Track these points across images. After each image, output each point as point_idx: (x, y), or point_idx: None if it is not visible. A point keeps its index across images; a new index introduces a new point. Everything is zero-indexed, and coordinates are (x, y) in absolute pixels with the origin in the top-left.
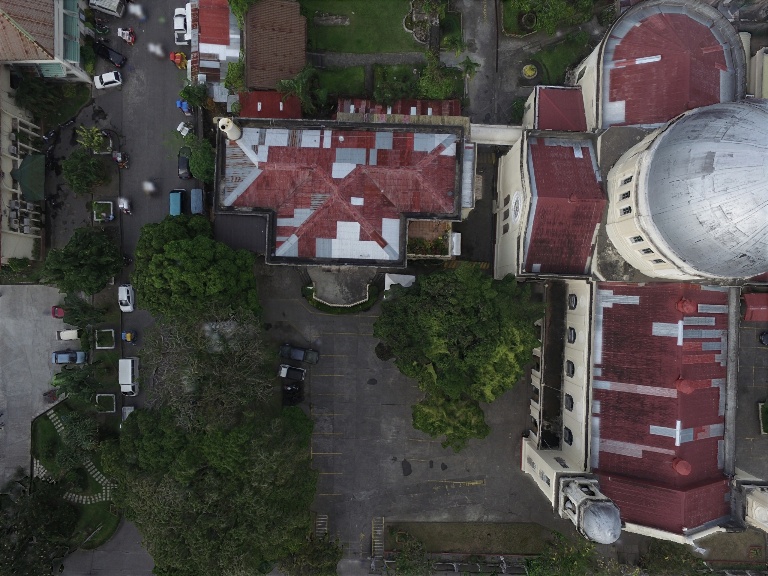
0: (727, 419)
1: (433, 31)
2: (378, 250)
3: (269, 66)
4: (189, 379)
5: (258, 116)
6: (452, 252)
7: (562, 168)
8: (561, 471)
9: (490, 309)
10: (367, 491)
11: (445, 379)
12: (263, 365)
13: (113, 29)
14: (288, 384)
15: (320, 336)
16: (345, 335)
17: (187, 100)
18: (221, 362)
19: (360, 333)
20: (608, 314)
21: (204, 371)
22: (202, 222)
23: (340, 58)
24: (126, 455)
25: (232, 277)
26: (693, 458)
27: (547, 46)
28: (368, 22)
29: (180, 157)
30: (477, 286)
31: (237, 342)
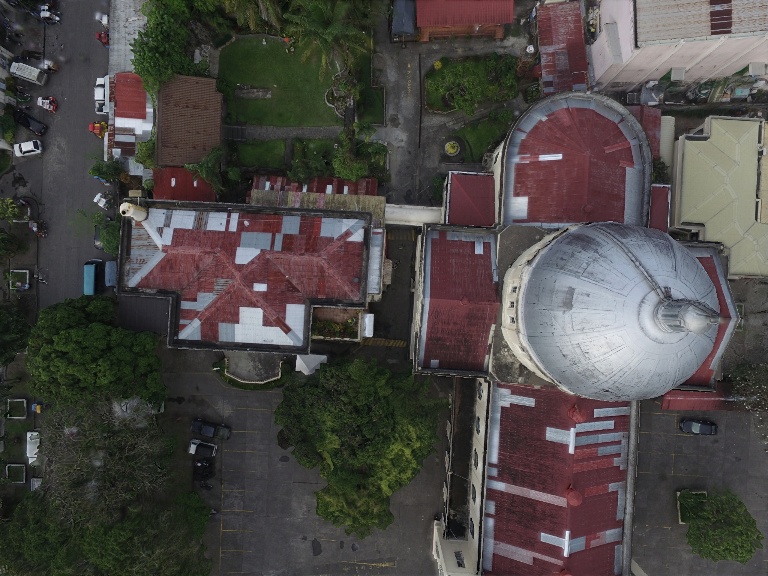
0: (626, 524)
1: (347, 112)
2: (282, 336)
3: (182, 144)
4: (71, 475)
5: (172, 191)
6: (364, 333)
7: (460, 266)
8: (451, 575)
9: (383, 407)
10: (276, 570)
11: (337, 476)
12: (159, 452)
13: (36, 96)
14: (199, 459)
15: (233, 411)
16: (258, 411)
17: (98, 176)
18: (107, 456)
19: (273, 409)
20: (505, 414)
21: (87, 466)
22: (102, 305)
23: (261, 131)
24: (14, 543)
25: (127, 365)
26: (585, 567)
27: (470, 123)
28: (290, 95)
29: (97, 228)
30: (370, 383)
31: (125, 435)
